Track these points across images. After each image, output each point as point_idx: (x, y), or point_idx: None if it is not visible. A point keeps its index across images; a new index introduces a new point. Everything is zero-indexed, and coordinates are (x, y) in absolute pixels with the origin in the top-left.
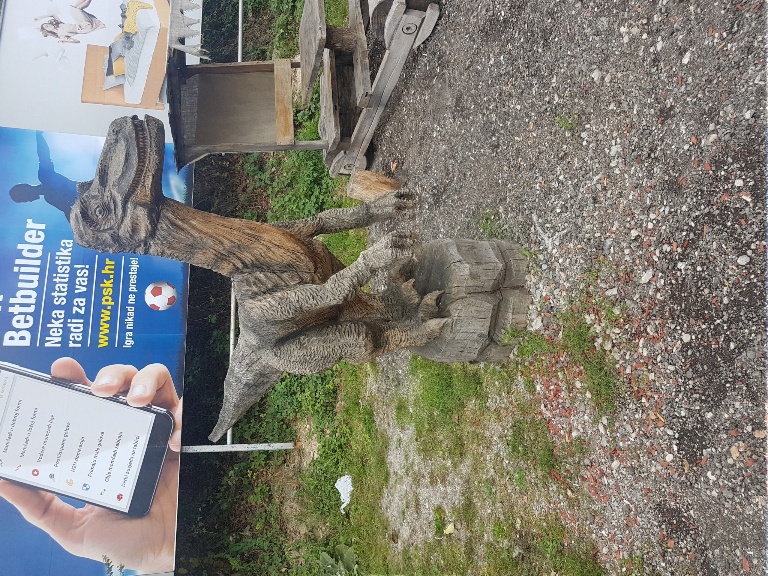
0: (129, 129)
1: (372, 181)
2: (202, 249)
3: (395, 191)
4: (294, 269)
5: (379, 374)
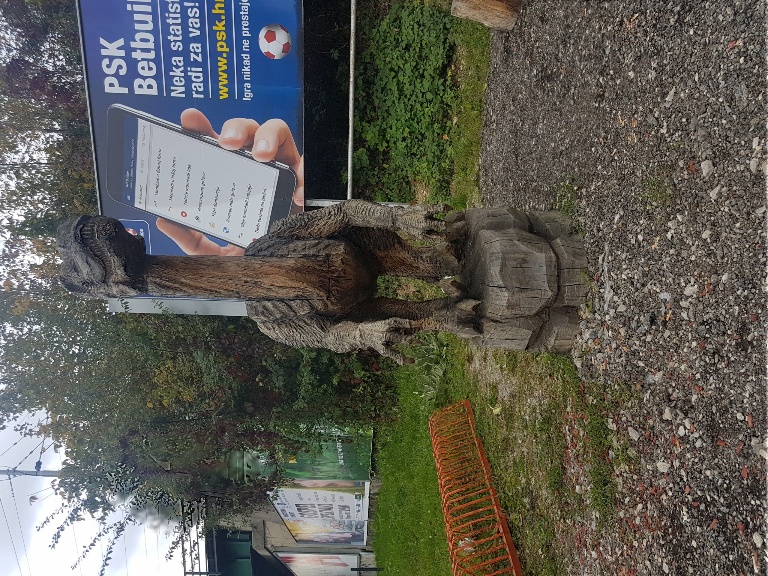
0: (79, 246)
1: None
2: None
3: (425, 211)
4: (304, 298)
5: None
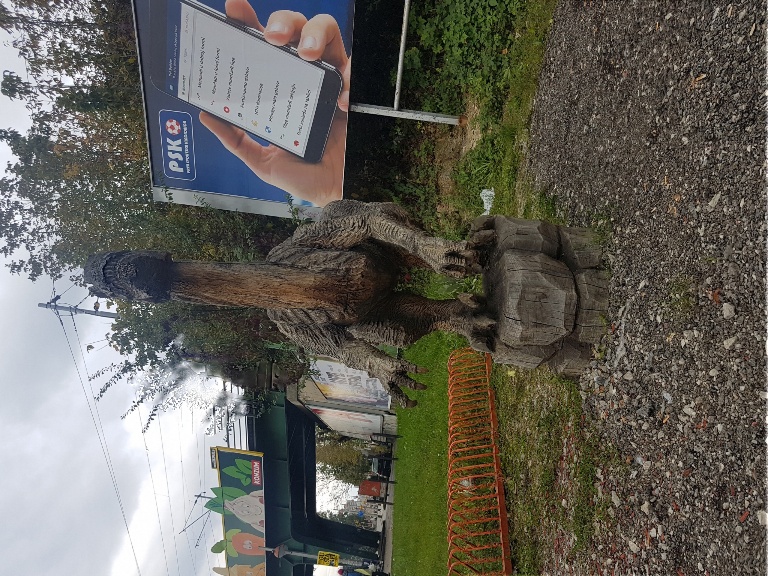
0: (102, 283)
1: None
2: None
3: (446, 248)
4: (321, 308)
5: None
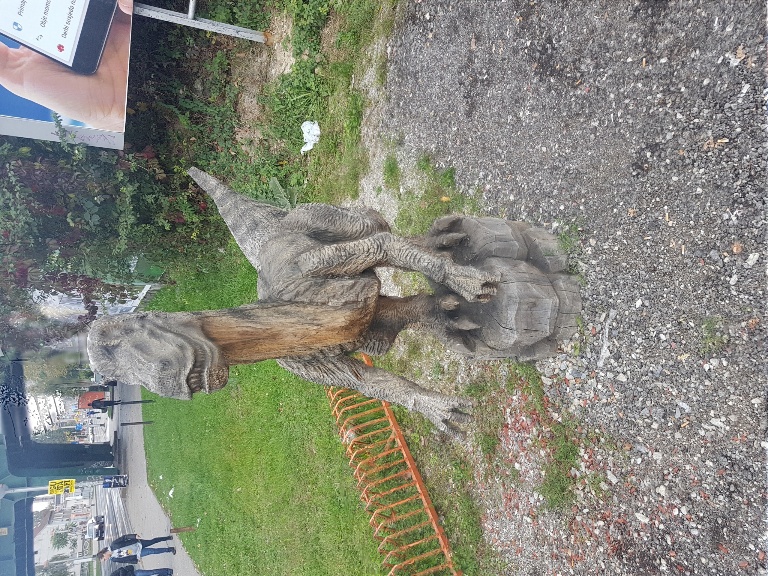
0: (184, 396)
1: None
2: None
3: (484, 281)
4: None
5: (383, 89)
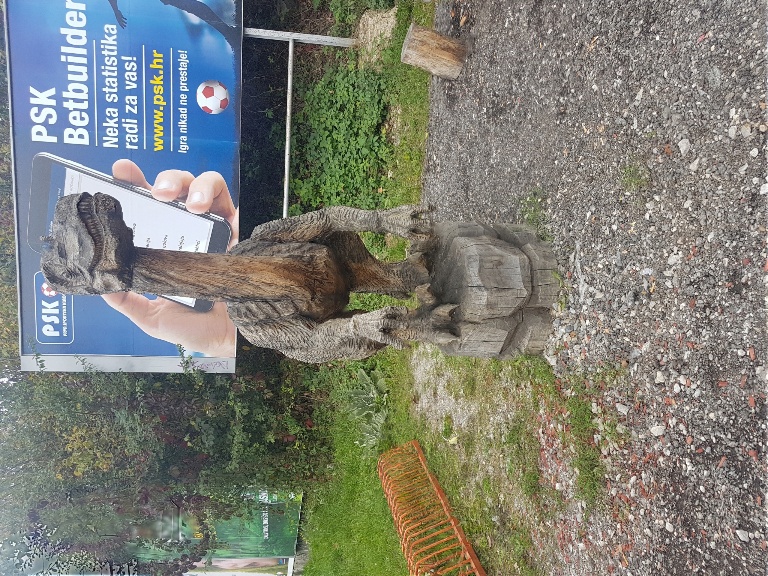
0: (75, 220)
1: (431, 47)
2: (185, 292)
3: (411, 209)
4: (289, 298)
5: None
